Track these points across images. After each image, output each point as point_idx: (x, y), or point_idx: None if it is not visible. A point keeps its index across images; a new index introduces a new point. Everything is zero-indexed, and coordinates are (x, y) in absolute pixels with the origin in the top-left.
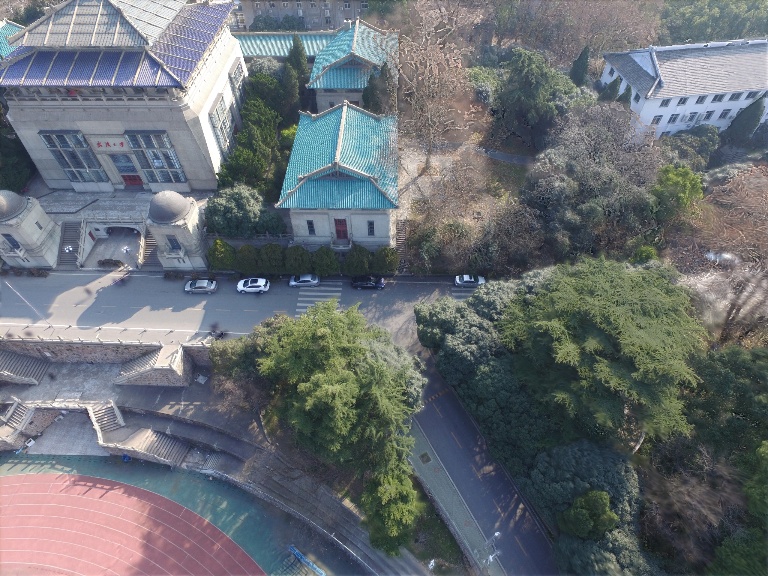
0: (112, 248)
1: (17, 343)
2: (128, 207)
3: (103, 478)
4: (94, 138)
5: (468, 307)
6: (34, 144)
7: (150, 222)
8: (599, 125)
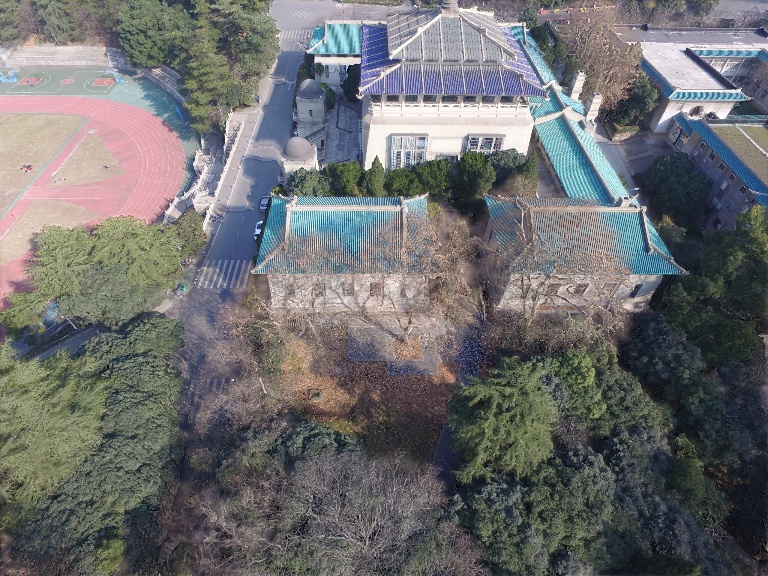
0: None
1: None
2: (342, 147)
3: None
4: None
5: (144, 352)
6: None
7: None
8: (456, 574)
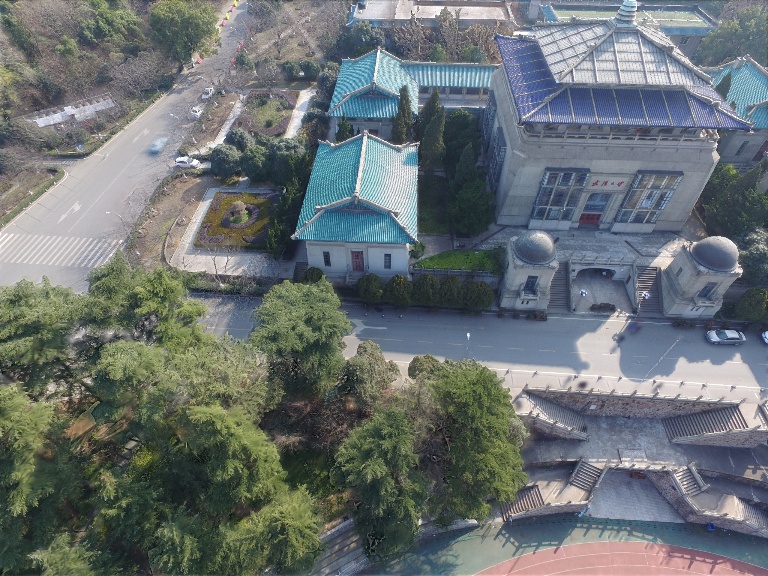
0: (588, 290)
1: (577, 395)
2: (599, 247)
3: (698, 550)
4: (597, 177)
5: None
6: (525, 181)
7: (705, 269)
8: None
